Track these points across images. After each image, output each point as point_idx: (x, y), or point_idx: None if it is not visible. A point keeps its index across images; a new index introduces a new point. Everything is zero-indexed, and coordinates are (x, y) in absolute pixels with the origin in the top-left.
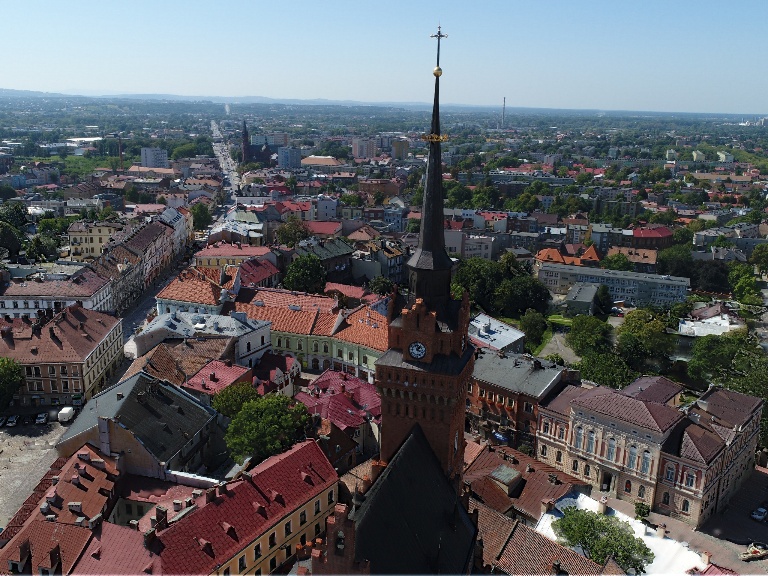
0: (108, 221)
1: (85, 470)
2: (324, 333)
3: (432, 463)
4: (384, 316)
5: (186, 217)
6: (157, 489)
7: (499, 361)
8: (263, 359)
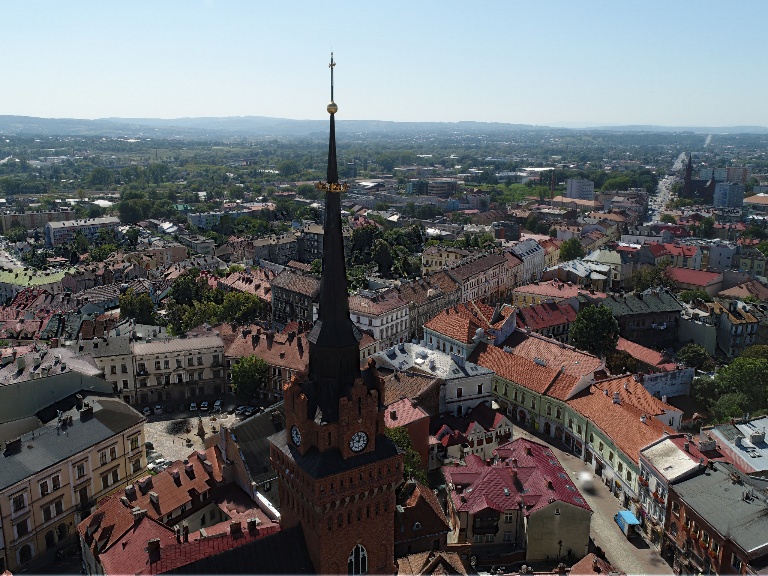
0: (458, 247)
1: (192, 468)
2: (558, 396)
3: (301, 575)
4: (648, 392)
5: (548, 250)
6: (242, 505)
7: (728, 486)
8: (476, 409)
